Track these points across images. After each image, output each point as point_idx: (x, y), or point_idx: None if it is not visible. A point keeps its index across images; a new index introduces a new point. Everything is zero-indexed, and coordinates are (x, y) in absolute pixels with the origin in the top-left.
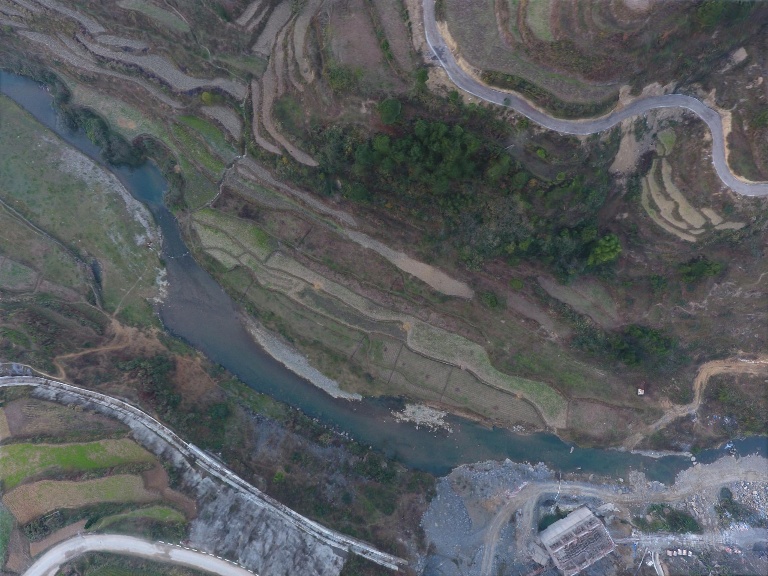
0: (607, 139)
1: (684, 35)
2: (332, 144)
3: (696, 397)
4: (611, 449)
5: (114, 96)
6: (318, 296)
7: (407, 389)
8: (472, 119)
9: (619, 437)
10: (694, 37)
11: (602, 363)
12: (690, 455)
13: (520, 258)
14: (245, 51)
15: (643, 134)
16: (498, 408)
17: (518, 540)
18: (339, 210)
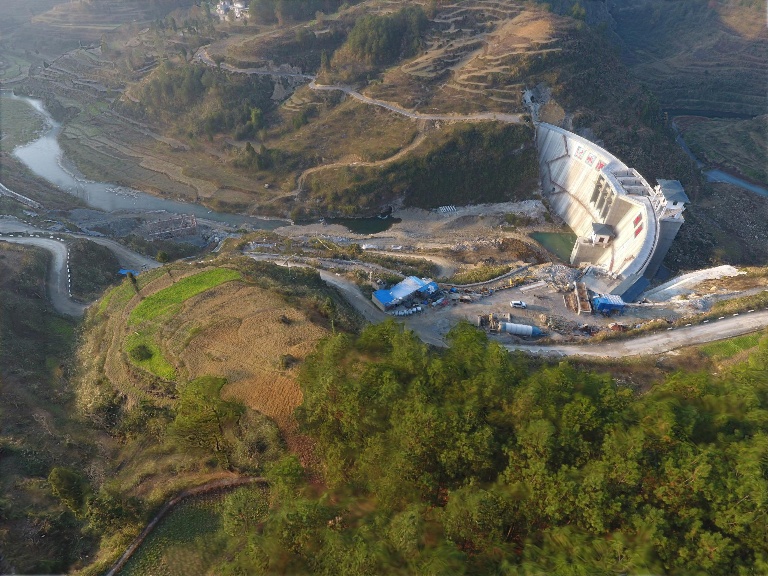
0: (261, 77)
1: (295, 47)
2: (145, 86)
3: (299, 187)
4: (237, 214)
5: (72, 98)
6: (106, 148)
7: (124, 178)
8: (204, 71)
9: (243, 205)
10: (302, 50)
11: (248, 174)
12: (291, 221)
13: (219, 131)
14: (136, 79)
15: (288, 87)
16: (173, 188)
17: (134, 230)
18: (142, 123)
